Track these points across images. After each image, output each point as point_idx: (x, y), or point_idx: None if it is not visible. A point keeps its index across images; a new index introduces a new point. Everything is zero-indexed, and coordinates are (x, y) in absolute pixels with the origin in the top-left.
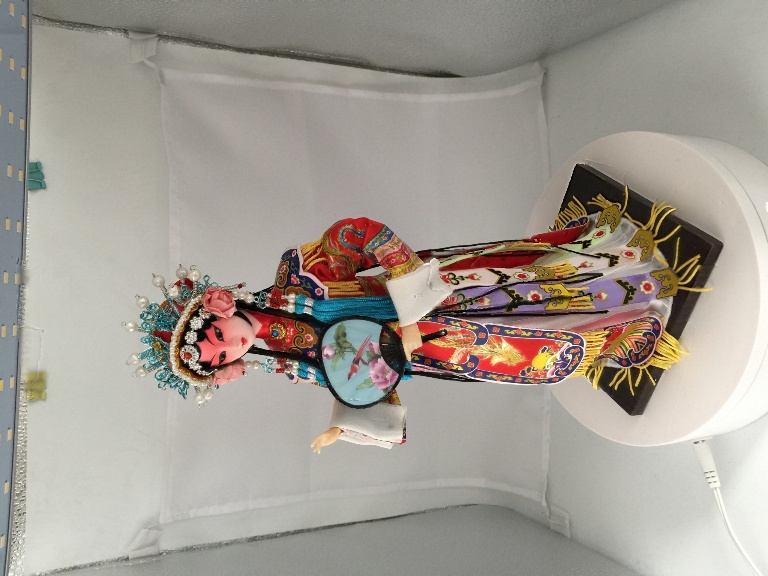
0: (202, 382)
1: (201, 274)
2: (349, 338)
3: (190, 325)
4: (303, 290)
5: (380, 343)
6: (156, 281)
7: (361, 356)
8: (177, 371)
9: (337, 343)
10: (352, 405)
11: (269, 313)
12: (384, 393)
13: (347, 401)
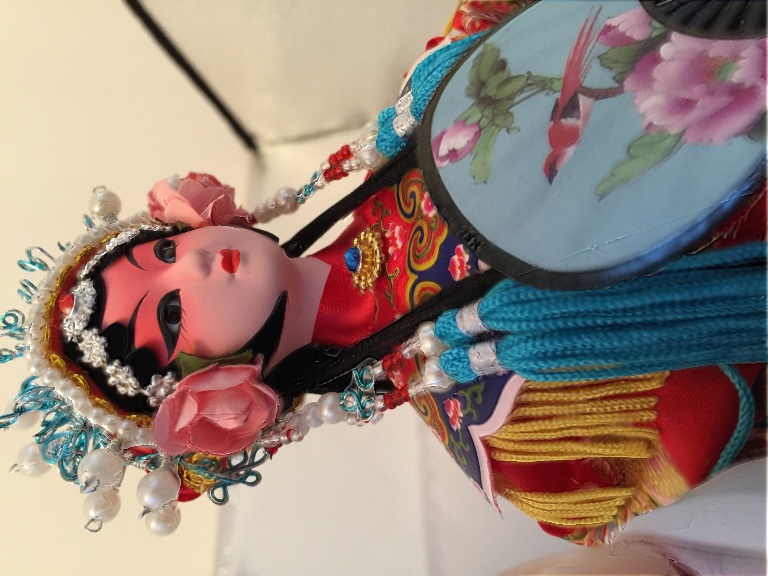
0: (127, 421)
1: None
2: (518, 65)
3: (107, 246)
4: None
5: (646, 4)
6: None
7: (580, 83)
8: (42, 361)
9: (479, 102)
10: (600, 273)
11: (333, 212)
12: (760, 145)
13: (568, 266)
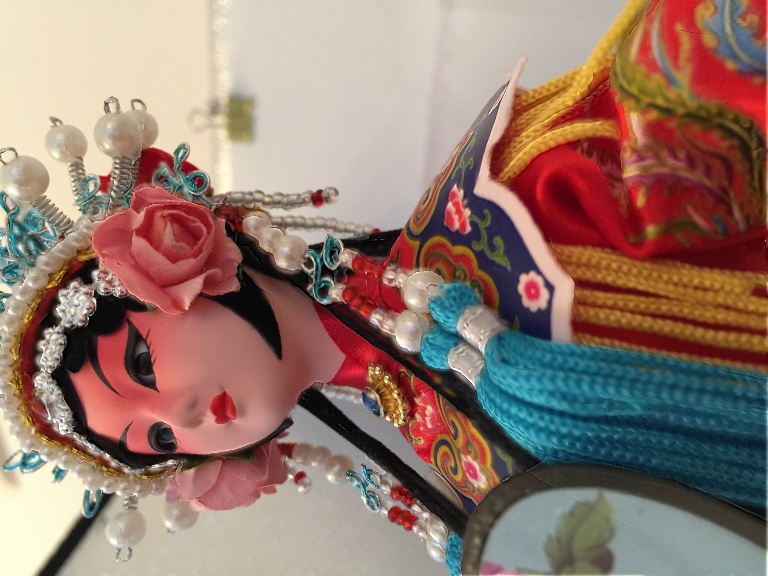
0: (139, 481)
1: (137, 135)
2: None
3: (58, 306)
4: (476, 266)
5: None
6: (58, 144)
7: None
8: (33, 438)
9: None
10: None
11: (352, 325)
12: None
13: None
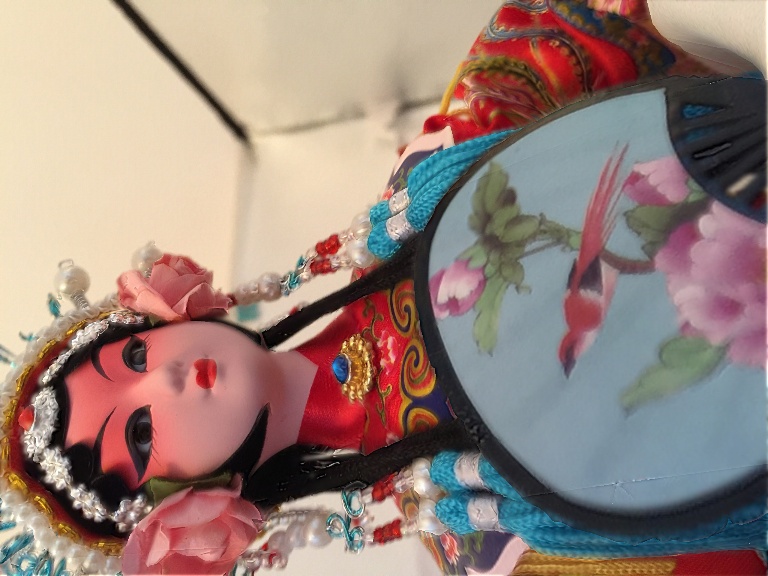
0: (93, 550)
1: None
2: (529, 200)
3: (73, 340)
4: None
5: (681, 153)
6: None
7: (603, 245)
8: None
9: (484, 240)
10: (626, 521)
11: (320, 308)
12: None
13: (588, 500)
